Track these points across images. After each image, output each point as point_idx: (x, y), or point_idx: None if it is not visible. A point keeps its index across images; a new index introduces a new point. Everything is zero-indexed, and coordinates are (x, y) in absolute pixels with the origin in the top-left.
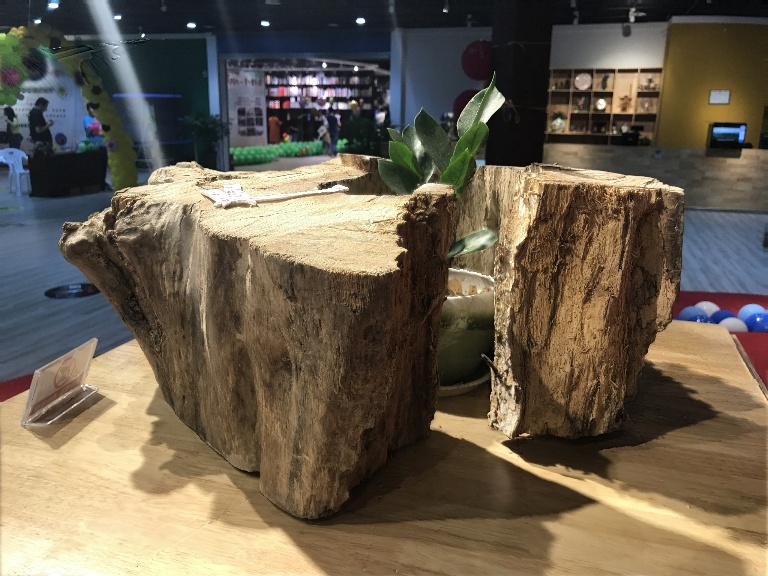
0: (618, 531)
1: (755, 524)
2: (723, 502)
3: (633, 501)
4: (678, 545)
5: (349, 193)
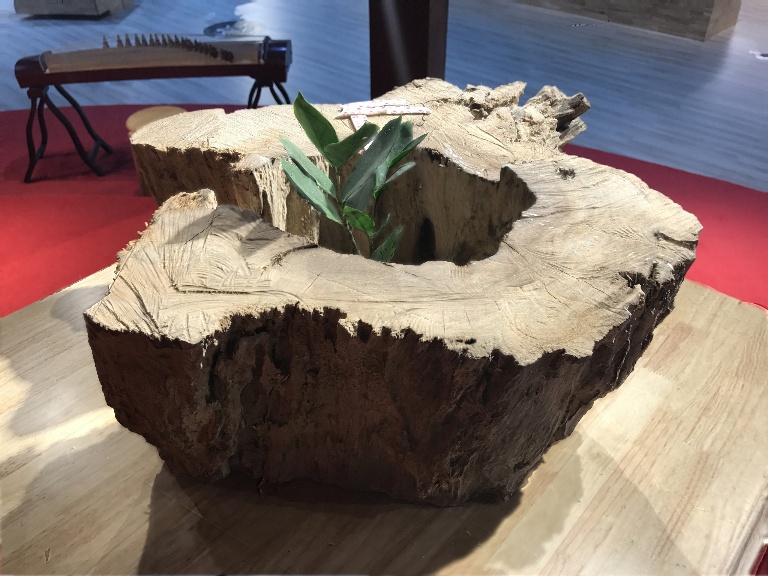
0: (99, 392)
1: (24, 475)
2: (55, 476)
3: (109, 420)
4: (61, 413)
5: (458, 182)
